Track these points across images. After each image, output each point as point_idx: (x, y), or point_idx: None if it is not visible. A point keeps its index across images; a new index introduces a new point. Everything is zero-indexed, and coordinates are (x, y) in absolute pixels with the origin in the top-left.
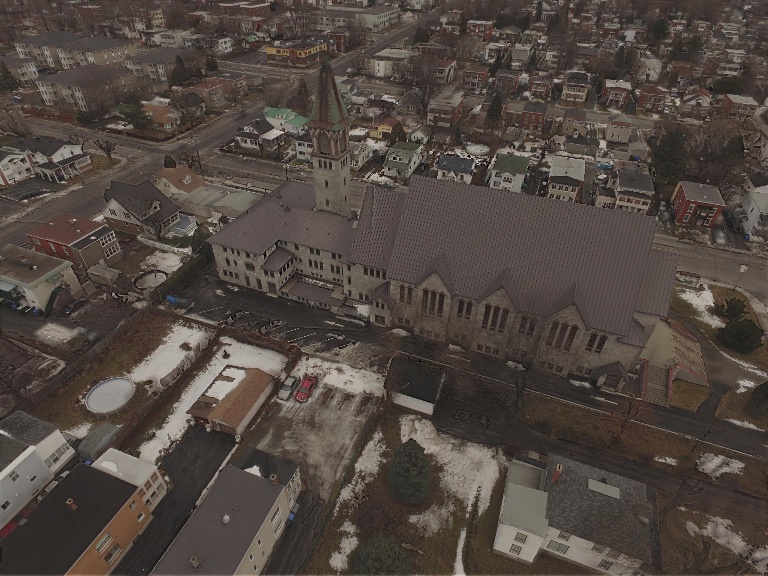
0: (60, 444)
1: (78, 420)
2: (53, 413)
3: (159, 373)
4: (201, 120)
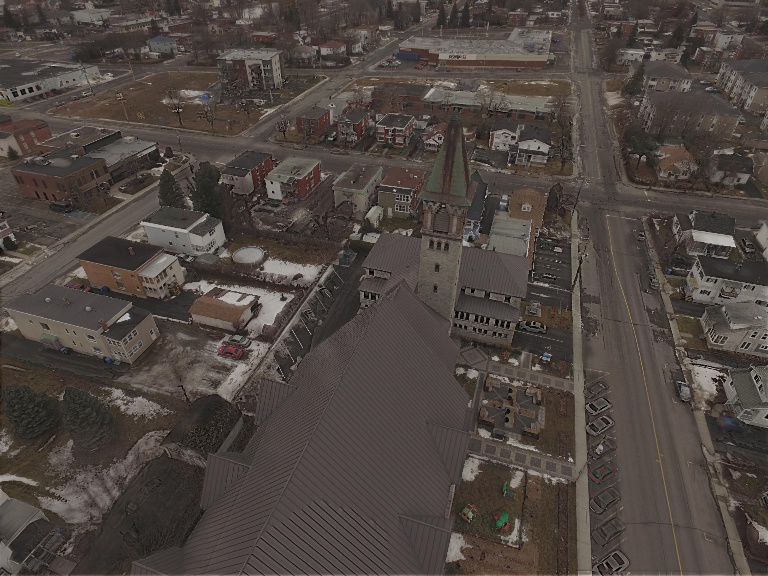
0: (201, 245)
1: (234, 251)
2: (243, 241)
3: (271, 271)
4: (716, 189)
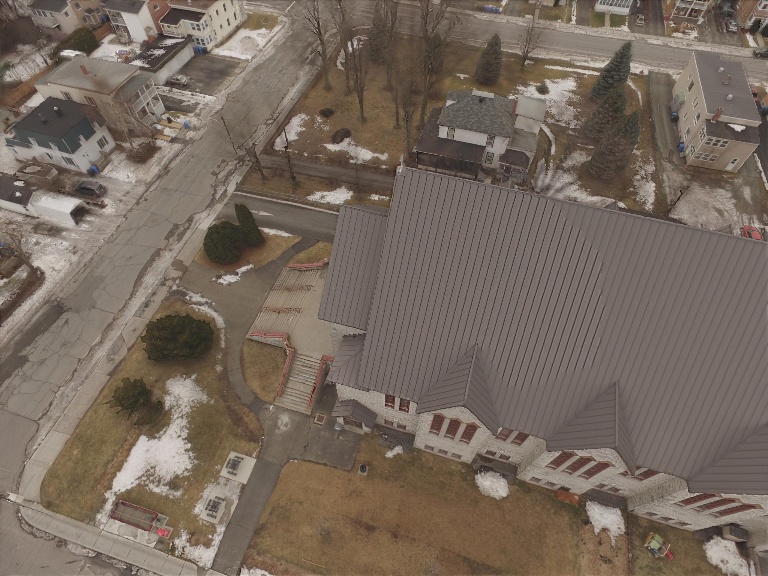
0: None
1: None
2: None
3: None
4: None
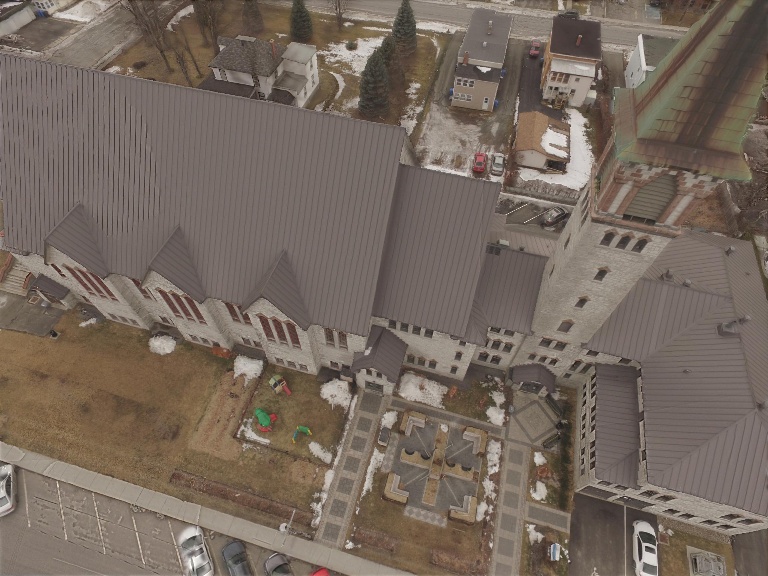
0: None
1: None
2: None
3: None
4: None
